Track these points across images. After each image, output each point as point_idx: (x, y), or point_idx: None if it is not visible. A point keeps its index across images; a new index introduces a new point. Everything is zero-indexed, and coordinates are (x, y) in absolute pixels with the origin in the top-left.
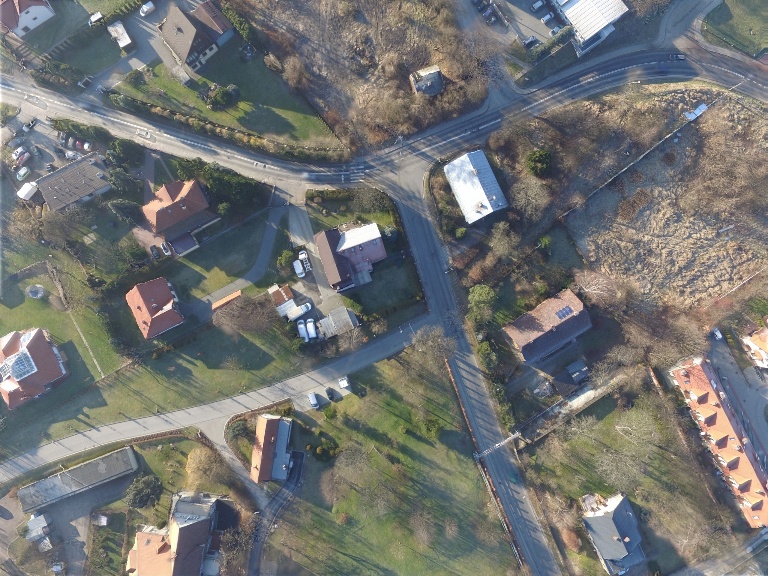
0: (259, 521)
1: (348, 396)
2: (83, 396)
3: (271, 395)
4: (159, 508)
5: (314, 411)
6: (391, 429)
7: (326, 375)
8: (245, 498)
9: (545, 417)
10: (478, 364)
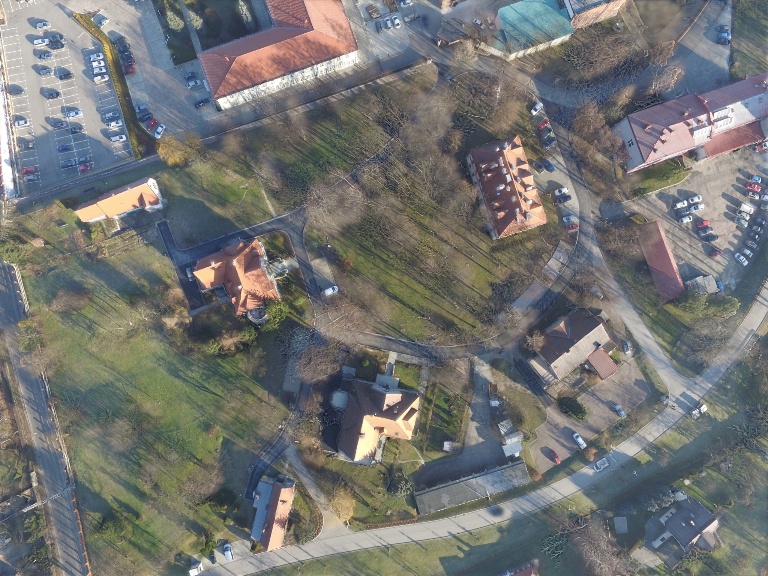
0: (296, 433)
1: (195, 553)
2: (463, 569)
3: (273, 558)
4: (395, 450)
5: (231, 540)
6: (154, 519)
7: (216, 575)
8: (305, 461)
9: (1, 516)
10: (62, 574)
